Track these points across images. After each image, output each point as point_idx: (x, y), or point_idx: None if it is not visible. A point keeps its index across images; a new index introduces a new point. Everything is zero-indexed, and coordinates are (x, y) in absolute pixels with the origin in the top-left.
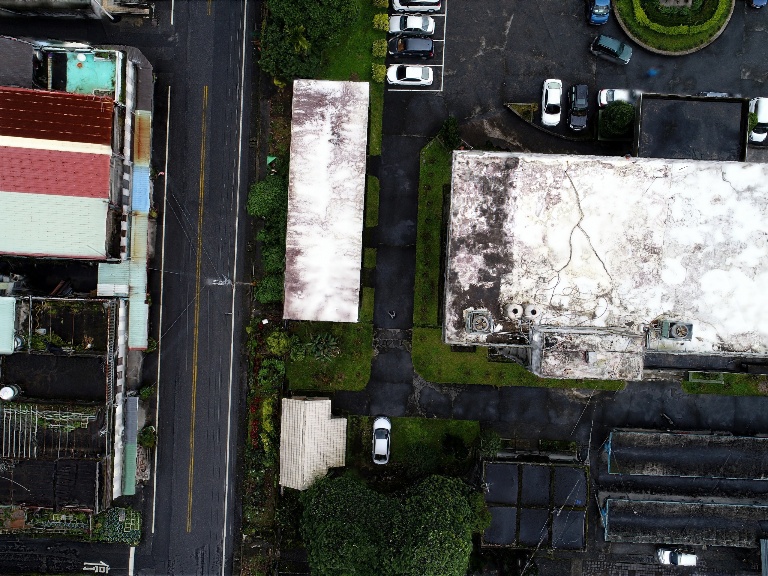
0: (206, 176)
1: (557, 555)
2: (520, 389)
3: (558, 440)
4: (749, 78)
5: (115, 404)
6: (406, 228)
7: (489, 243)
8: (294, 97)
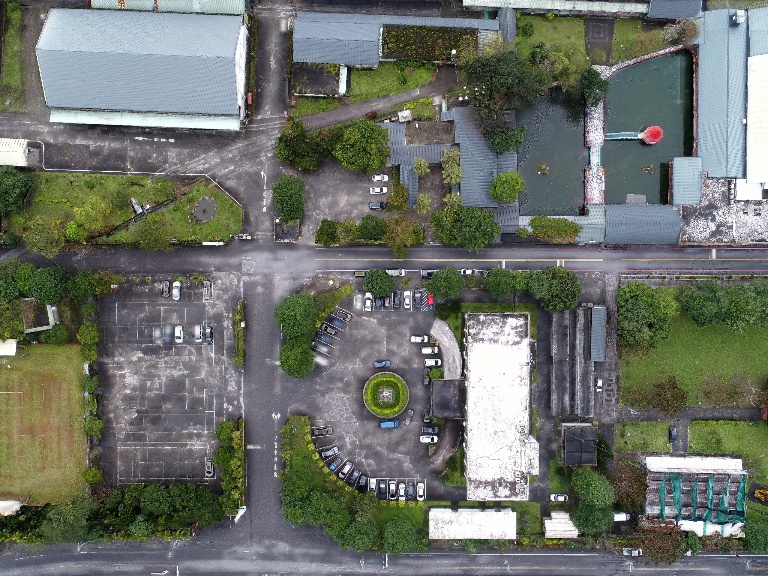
0: (461, 566)
1: (600, 429)
2: None
3: (556, 430)
4: (416, 365)
5: None
6: None
7: (495, 486)
8: (435, 538)
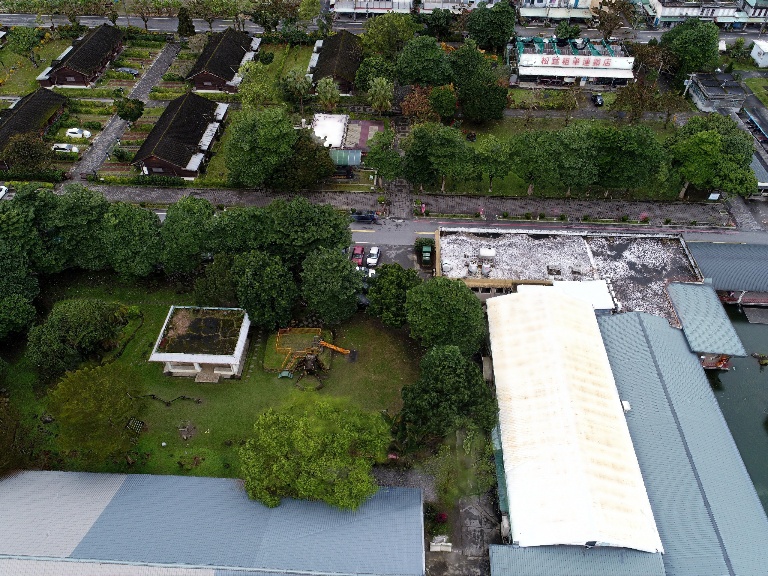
0: None
1: None
2: (759, 100)
3: None
4: None
5: (701, 7)
6: None
7: None
8: None
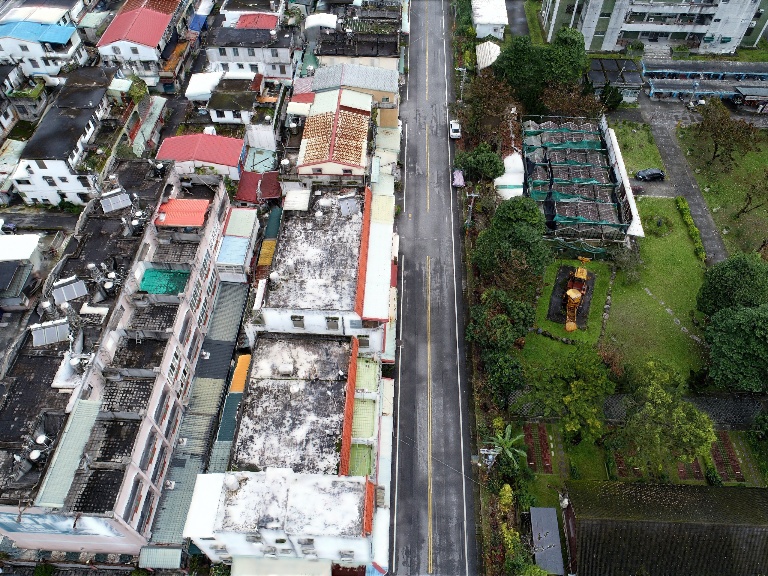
0: None
1: None
2: None
3: None
4: None
5: (401, 30)
6: (522, 20)
7: None
8: None
